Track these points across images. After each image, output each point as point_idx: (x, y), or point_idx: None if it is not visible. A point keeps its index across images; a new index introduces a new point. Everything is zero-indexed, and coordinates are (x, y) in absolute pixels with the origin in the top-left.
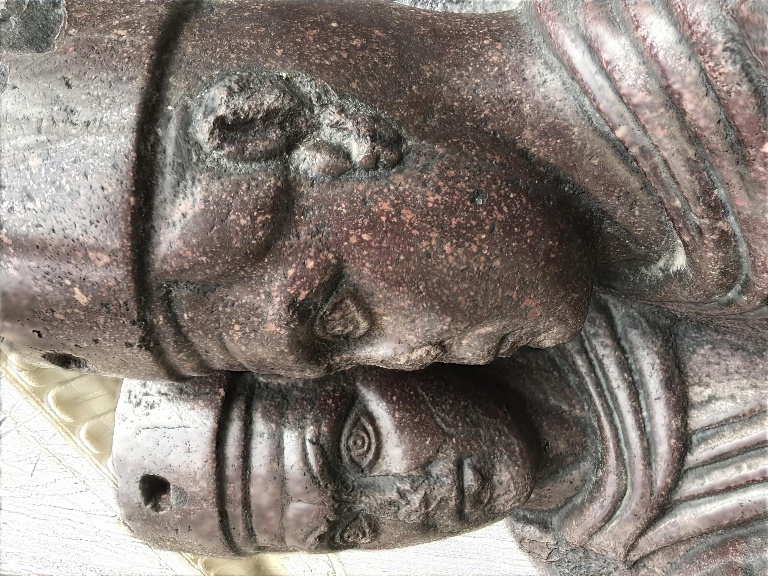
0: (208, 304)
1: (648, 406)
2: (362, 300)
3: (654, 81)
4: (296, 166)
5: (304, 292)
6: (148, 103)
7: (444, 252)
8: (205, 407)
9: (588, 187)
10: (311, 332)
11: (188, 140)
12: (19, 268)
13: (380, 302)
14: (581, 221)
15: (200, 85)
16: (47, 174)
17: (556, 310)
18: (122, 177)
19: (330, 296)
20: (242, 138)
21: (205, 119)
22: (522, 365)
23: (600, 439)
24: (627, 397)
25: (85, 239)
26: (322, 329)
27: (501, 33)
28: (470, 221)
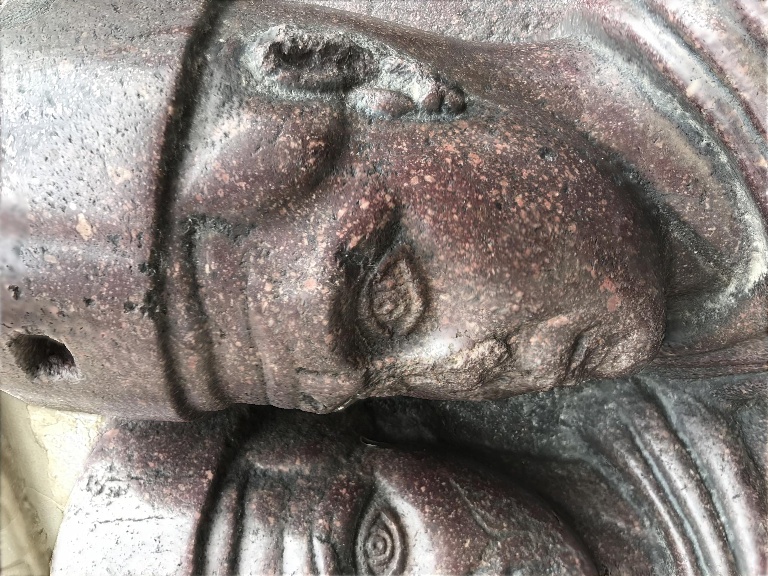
0: (237, 252)
1: (726, 508)
2: (419, 265)
3: (728, 18)
4: (353, 105)
5: (356, 237)
6: (200, 30)
7: (516, 205)
8: (186, 492)
9: (653, 175)
10: (355, 306)
11: (239, 67)
12: (16, 186)
13: (440, 269)
14: (649, 214)
15: (255, 28)
16: (77, 79)
17: (637, 303)
18: (163, 85)
19: (383, 253)
20: (297, 71)
21: (260, 45)
22: (563, 476)
23: (672, 560)
24: (698, 498)
25: (106, 150)
26: (369, 303)
27: (546, 43)
28: (542, 175)
